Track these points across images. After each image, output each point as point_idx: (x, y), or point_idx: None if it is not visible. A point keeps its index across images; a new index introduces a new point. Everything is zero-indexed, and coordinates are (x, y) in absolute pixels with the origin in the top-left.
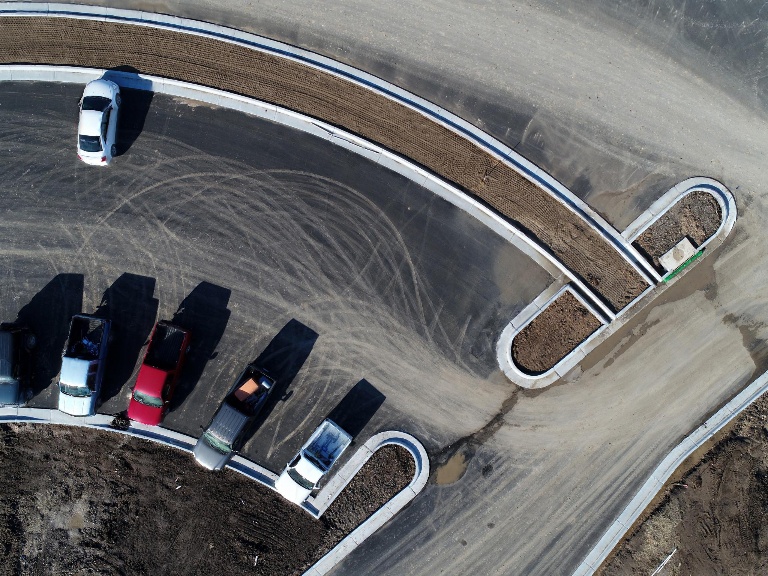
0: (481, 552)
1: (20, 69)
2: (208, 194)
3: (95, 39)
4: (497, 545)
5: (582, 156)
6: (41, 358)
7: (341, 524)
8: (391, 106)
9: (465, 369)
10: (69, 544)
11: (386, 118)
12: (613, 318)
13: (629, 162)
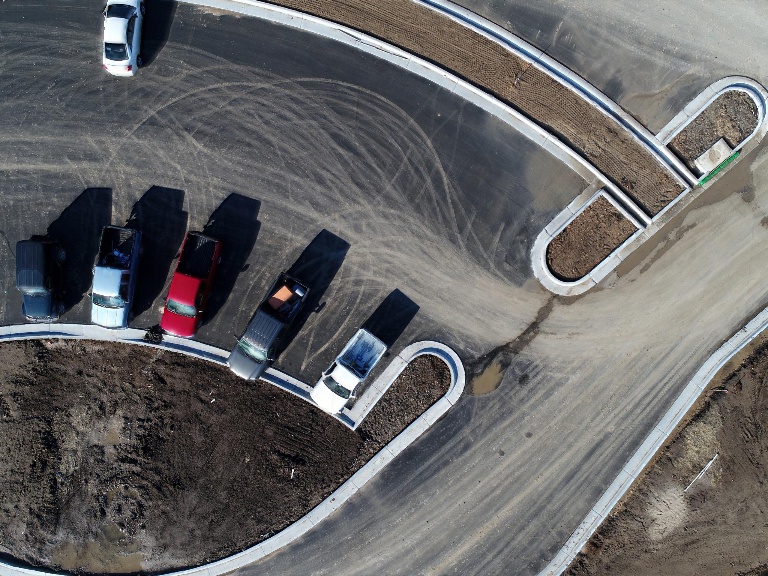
0: (519, 462)
1: None
2: (235, 104)
3: None
4: (535, 454)
5: (614, 57)
6: (72, 273)
7: (377, 436)
8: (419, 10)
9: (499, 277)
10: (104, 461)
11: (414, 23)
12: (649, 222)
13: (663, 62)
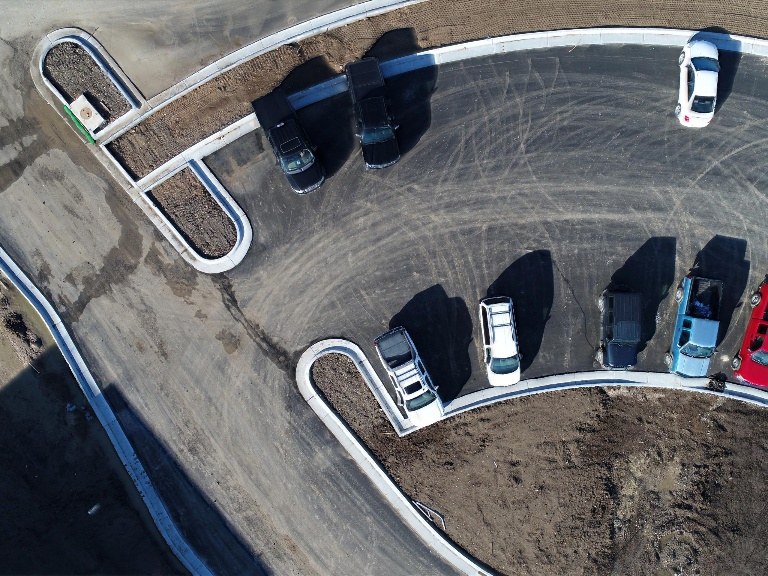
0: None
1: (610, 32)
2: None
3: (685, 0)
4: None
5: None
6: None
7: None
8: None
9: None
10: (660, 506)
11: None
12: None
13: None
